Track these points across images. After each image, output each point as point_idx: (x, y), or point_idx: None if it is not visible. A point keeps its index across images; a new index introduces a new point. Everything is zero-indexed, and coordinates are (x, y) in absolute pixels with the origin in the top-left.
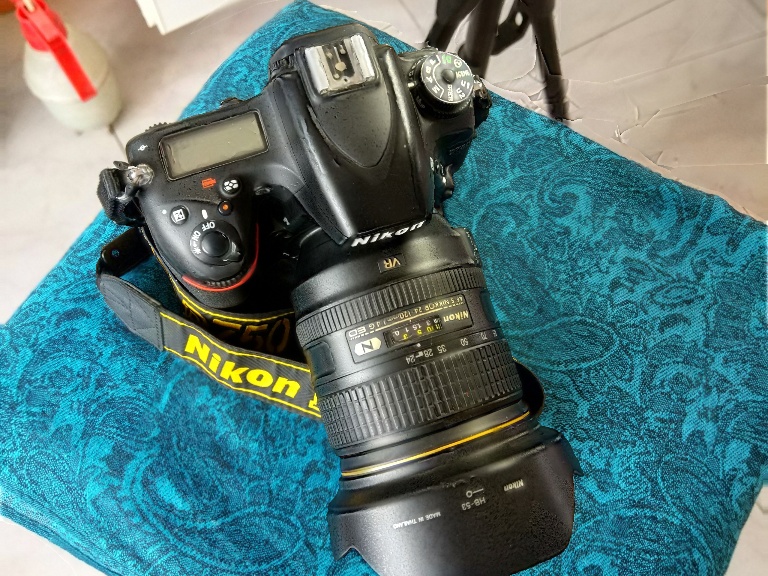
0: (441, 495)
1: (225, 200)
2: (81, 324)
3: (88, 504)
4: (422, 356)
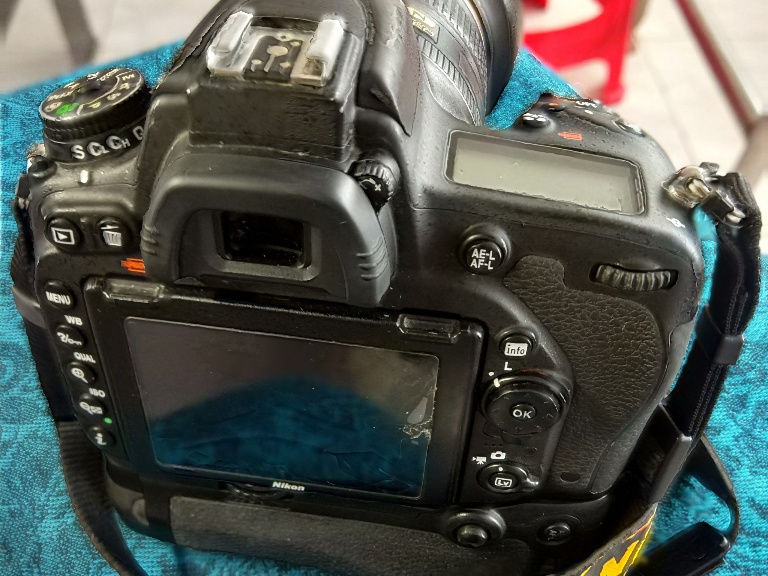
0: None
1: (551, 113)
2: (764, 494)
3: (763, 283)
4: None
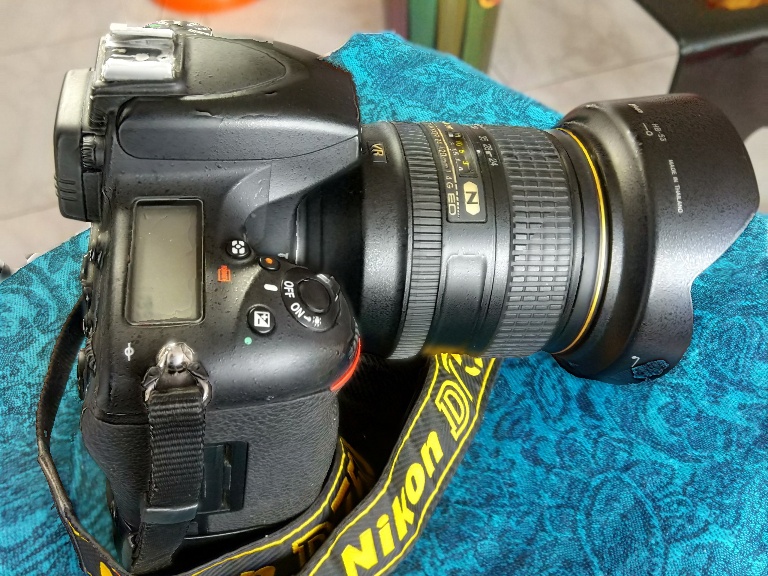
0: (650, 156)
1: (257, 260)
2: None
3: None
4: (490, 153)
